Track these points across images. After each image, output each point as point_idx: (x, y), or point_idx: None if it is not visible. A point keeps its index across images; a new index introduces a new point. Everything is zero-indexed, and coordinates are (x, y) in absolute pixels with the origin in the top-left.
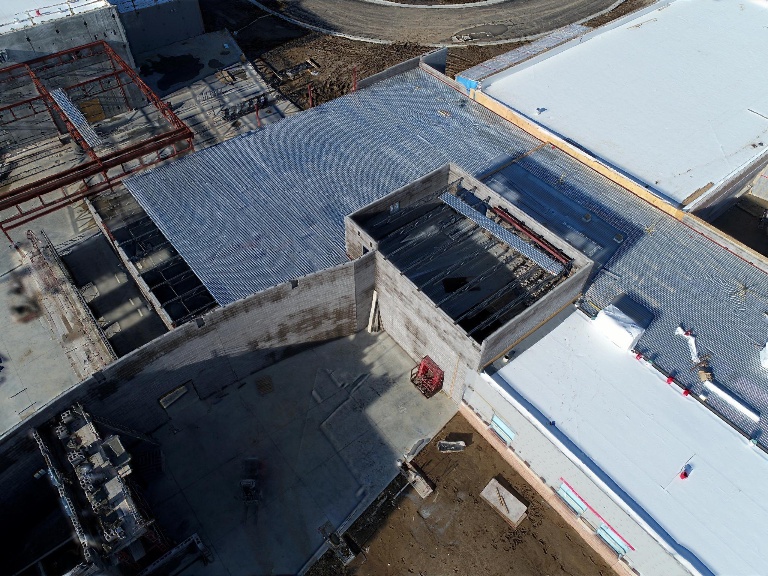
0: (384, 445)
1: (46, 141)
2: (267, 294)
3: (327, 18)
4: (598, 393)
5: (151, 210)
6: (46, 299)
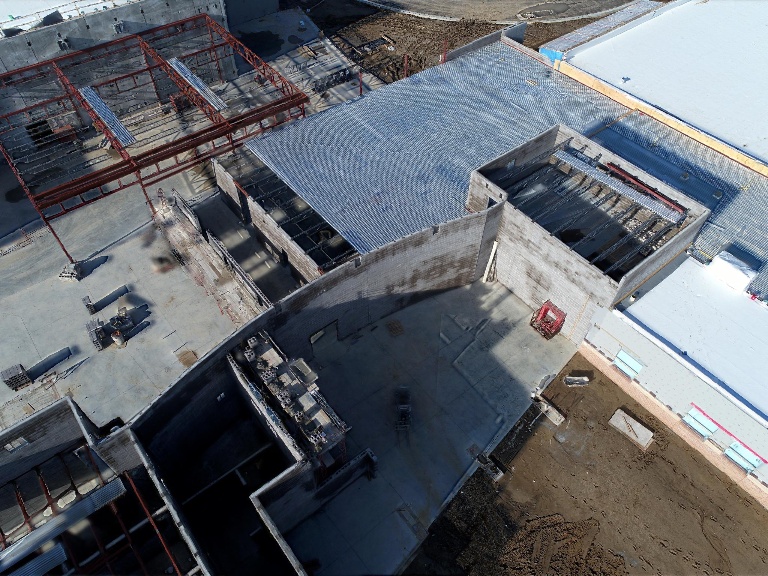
0: (514, 380)
1: (149, 110)
2: (413, 238)
3: None
4: (721, 328)
5: (277, 169)
6: (191, 249)
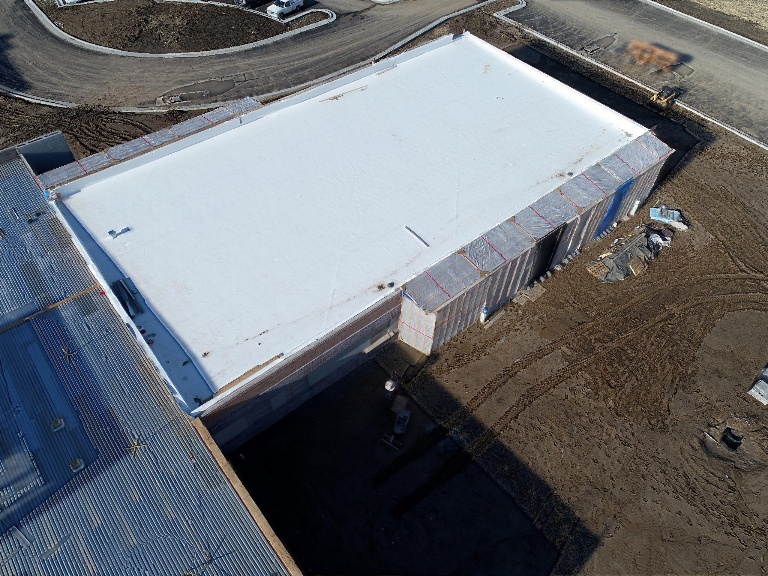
0: None
1: None
2: None
3: (20, 71)
4: None
5: None
6: None
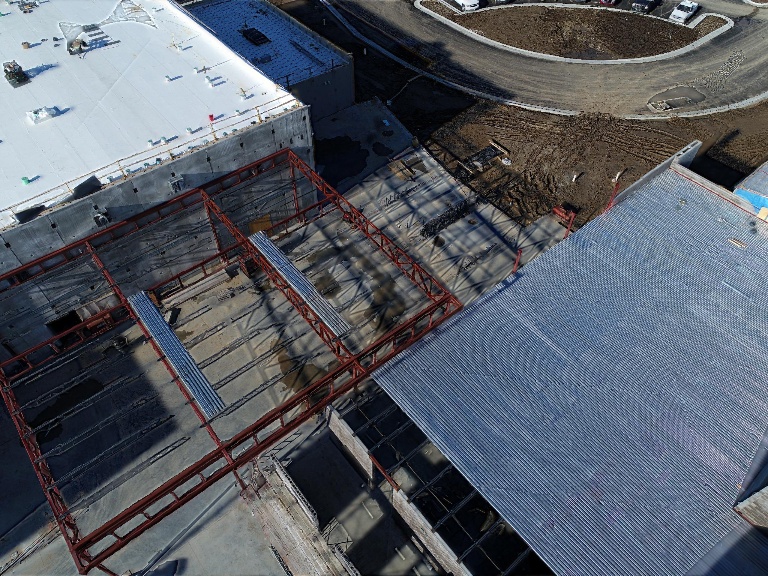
0: None
1: None
2: None
3: (488, 79)
4: None
5: (430, 429)
6: None
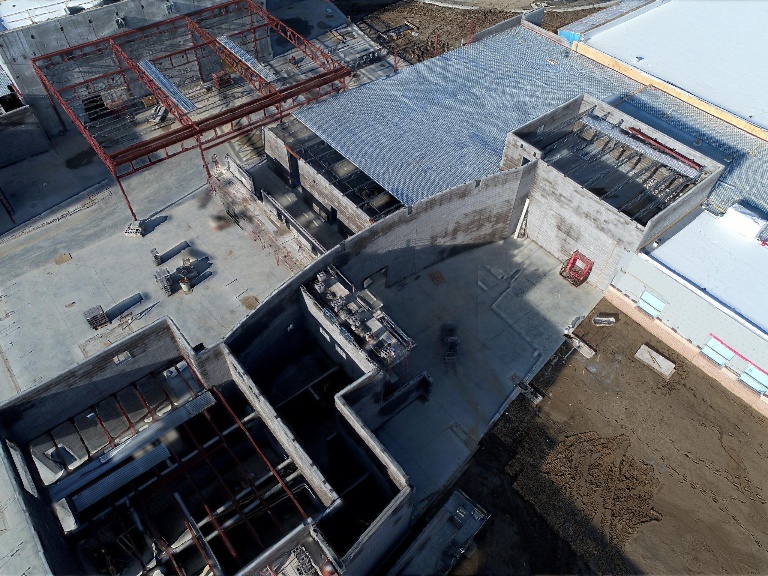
0: (548, 321)
1: None
2: (458, 190)
3: None
4: (736, 269)
5: (324, 135)
6: (250, 205)
